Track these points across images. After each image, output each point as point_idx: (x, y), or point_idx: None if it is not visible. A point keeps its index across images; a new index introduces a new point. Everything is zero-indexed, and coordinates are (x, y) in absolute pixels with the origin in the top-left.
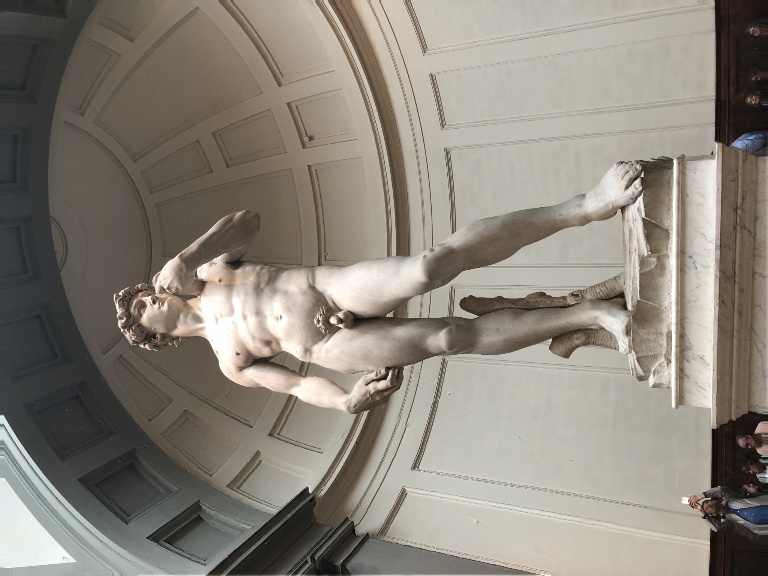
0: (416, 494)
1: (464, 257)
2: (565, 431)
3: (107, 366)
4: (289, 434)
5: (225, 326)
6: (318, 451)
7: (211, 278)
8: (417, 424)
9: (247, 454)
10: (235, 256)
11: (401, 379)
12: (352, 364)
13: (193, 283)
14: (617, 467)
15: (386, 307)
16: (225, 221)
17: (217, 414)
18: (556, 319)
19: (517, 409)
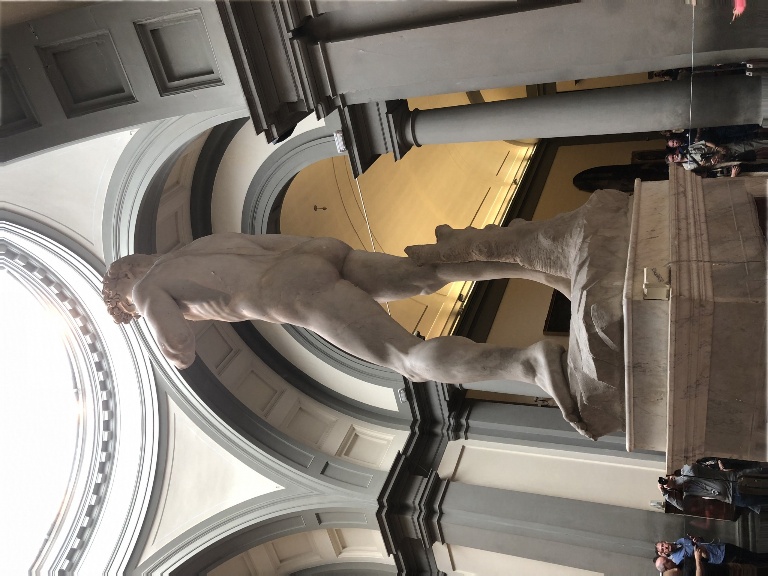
0: None
1: None
2: None
3: None
4: None
5: None
6: None
7: None
8: None
9: None
10: None
11: None
12: None
13: None
14: None
15: None
16: None
17: None
18: None
19: None
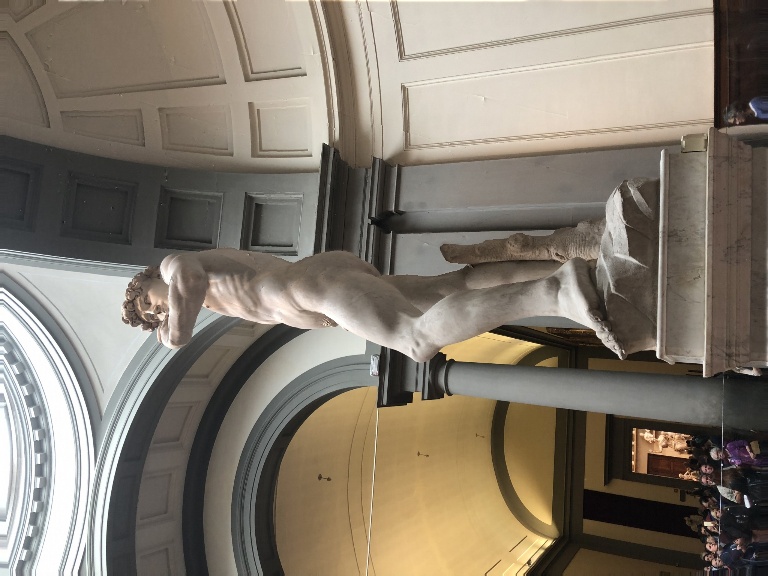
0: (416, 87)
1: None
2: None
3: (63, 133)
4: (261, 66)
5: None
6: (300, 73)
7: None
8: (380, 5)
9: (242, 110)
10: None
11: None
12: None
13: None
14: None
15: None
16: (177, 301)
17: (186, 91)
18: None
19: None
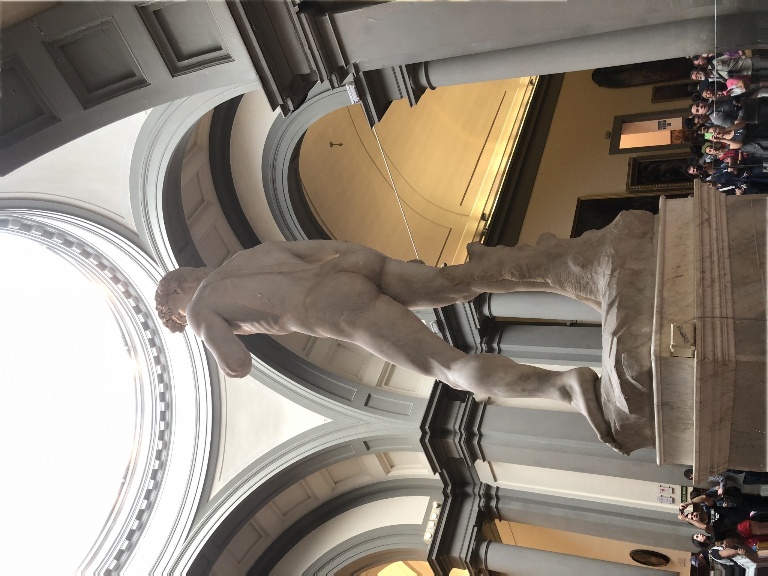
0: None
1: None
2: None
3: None
4: None
5: None
6: None
7: None
8: None
9: None
10: None
11: None
12: None
13: None
14: None
15: None
16: None
17: None
18: None
19: None
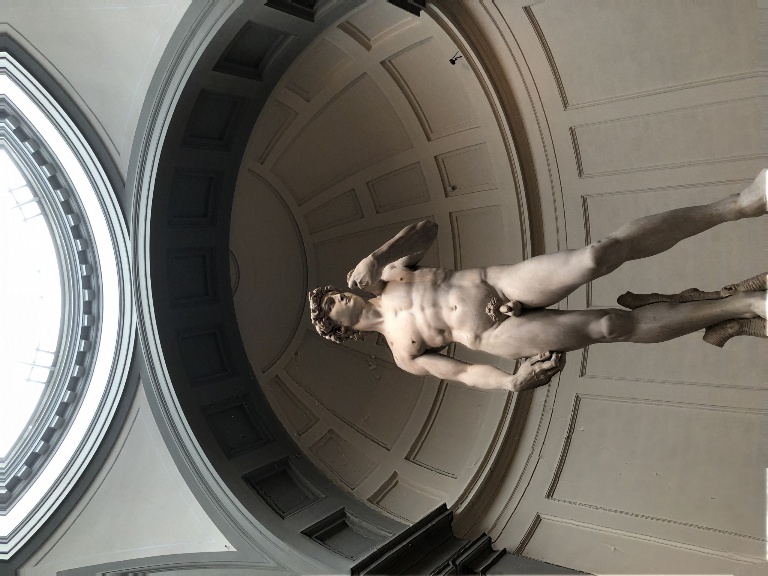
0: (550, 521)
1: (627, 247)
2: (706, 470)
3: (265, 383)
4: (424, 460)
5: (403, 318)
6: (452, 476)
7: (393, 278)
8: (550, 456)
9: (385, 474)
10: (414, 260)
11: (563, 361)
12: (519, 348)
13: (377, 282)
14: (764, 507)
15: (552, 296)
16: (410, 228)
17: (358, 436)
18: (711, 308)
19: (654, 447)
